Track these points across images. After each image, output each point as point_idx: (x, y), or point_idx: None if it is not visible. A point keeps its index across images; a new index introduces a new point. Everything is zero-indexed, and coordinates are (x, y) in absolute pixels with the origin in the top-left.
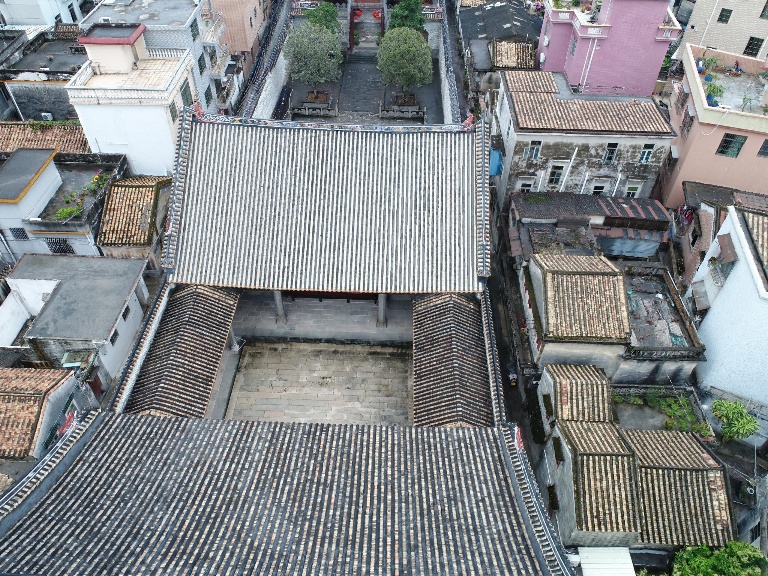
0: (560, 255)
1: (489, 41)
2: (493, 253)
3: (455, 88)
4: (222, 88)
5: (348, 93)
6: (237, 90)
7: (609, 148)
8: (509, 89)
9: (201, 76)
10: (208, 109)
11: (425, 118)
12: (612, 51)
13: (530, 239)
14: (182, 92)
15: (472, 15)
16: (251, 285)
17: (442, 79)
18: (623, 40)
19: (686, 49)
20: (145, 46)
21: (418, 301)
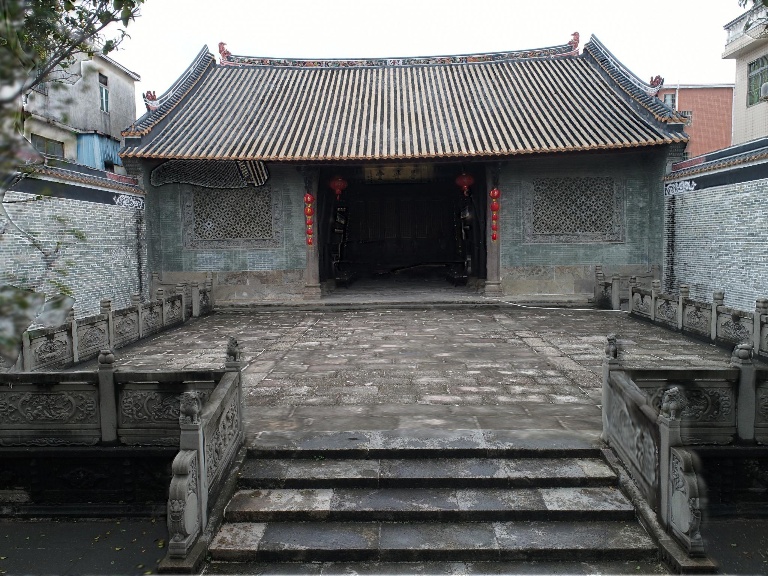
0: None
1: None
2: None
3: None
4: None
5: None
6: None
7: None
8: None
9: None
10: None
11: None
12: None
13: None
14: None
15: None
16: None
17: None
18: None
19: None
20: None
21: None
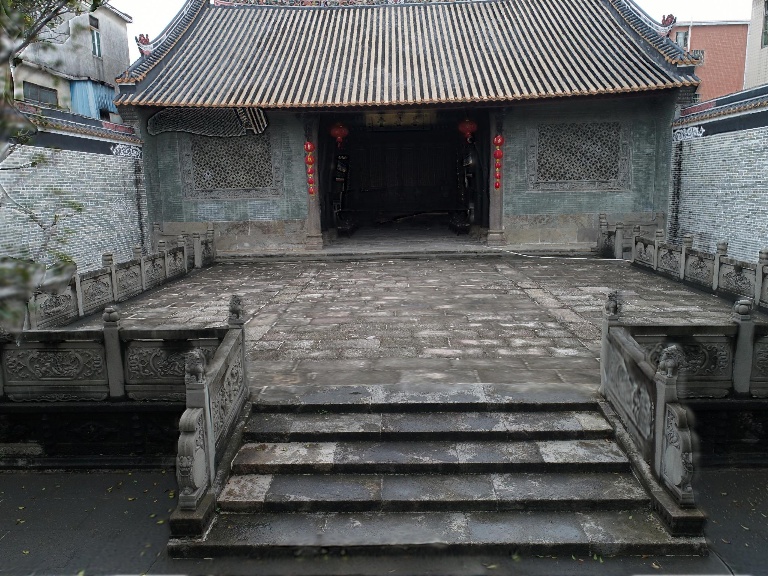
0: None
1: None
2: None
3: None
4: None
5: None
6: None
7: None
8: None
9: None
10: None
11: None
12: None
13: None
14: None
15: None
16: None
17: None
18: None
19: None
20: None
21: None
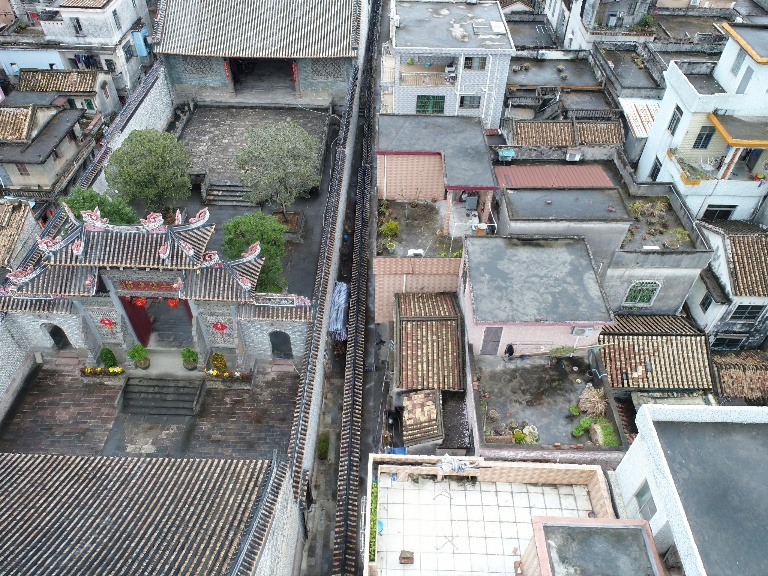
0: None
1: None
2: None
3: None
4: None
5: None
6: None
7: None
8: None
9: None
10: None
11: None
12: None
13: None
14: None
15: None
16: None
17: None
18: None
19: None
20: None
21: None
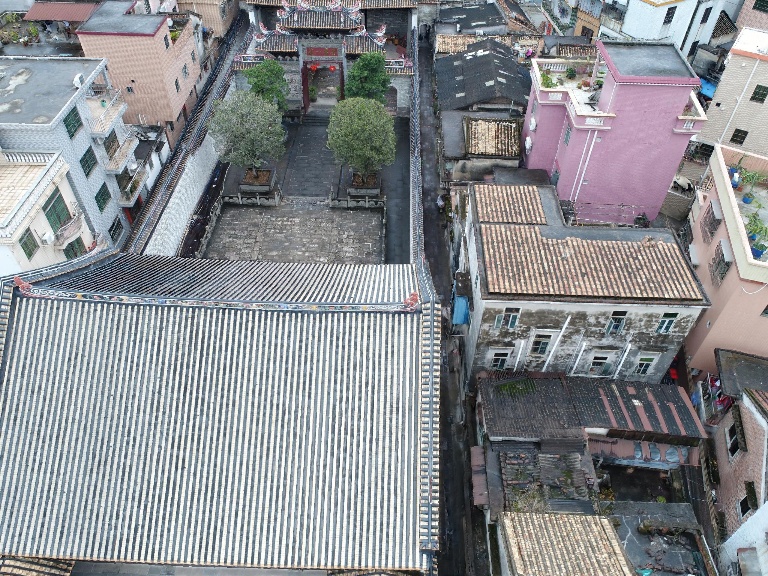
0: (543, 516)
1: (464, 113)
2: (460, 425)
3: (419, 179)
4: (130, 177)
5: (297, 169)
6: (159, 169)
7: (614, 316)
8: (478, 218)
9: (88, 176)
10: (103, 213)
11: (384, 211)
12: (617, 144)
13: (500, 475)
14: (49, 211)
15: (450, 65)
16: (86, 556)
17: (410, 152)
18: (631, 131)
19: (715, 153)
20: (0, 149)
21: (335, 574)
